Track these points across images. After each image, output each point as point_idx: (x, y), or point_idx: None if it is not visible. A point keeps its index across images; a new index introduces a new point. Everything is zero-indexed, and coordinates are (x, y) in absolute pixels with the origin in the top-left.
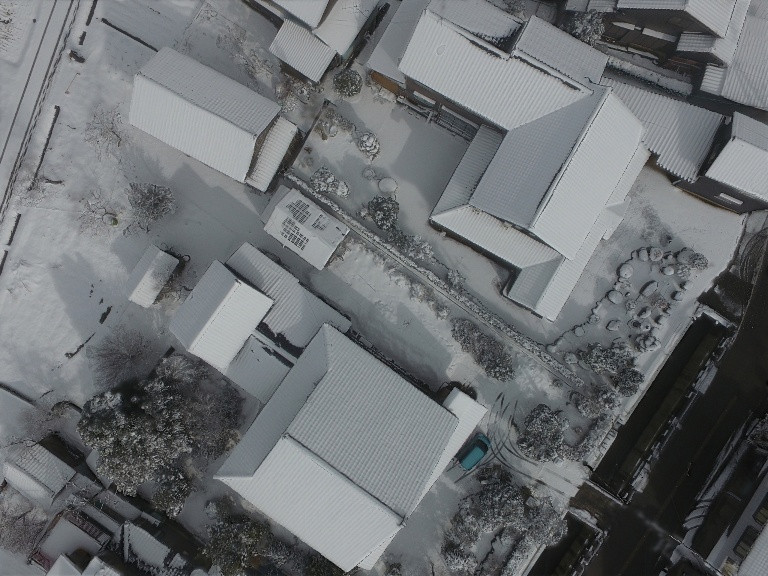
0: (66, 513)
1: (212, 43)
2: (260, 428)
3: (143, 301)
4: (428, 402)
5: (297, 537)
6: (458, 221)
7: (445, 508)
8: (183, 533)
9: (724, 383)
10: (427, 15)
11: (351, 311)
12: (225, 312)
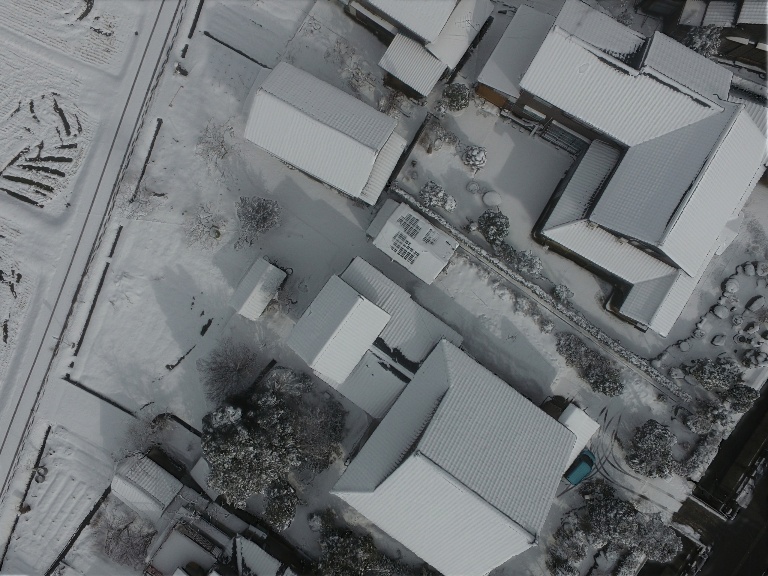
0: (179, 526)
1: (315, 56)
2: (378, 443)
3: (252, 314)
4: (546, 418)
5: (400, 550)
6: (571, 236)
7: (547, 522)
8: (285, 545)
9: None
10: (556, 31)
11: (455, 325)
12: (347, 328)
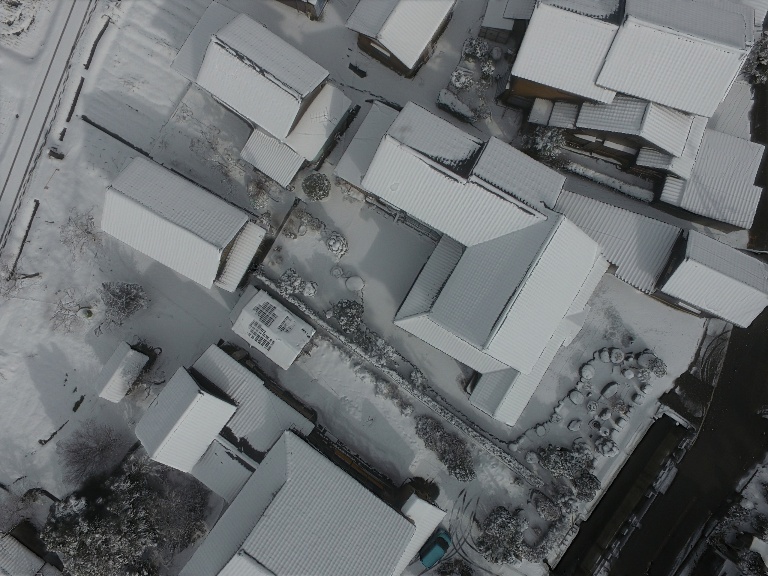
0: None
1: (187, 142)
2: (221, 532)
3: (113, 397)
4: (386, 510)
5: None
6: (420, 327)
7: None
8: None
9: (684, 484)
10: (387, 140)
11: (317, 406)
12: (188, 421)
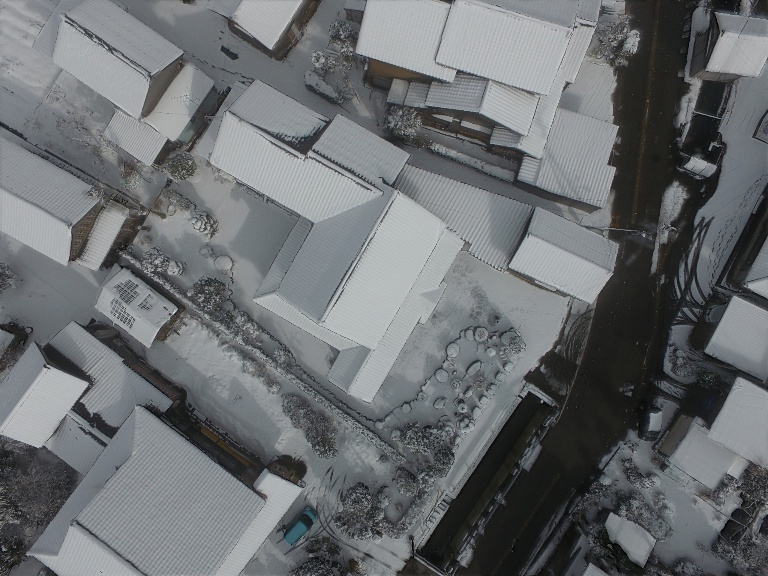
0: None
1: None
2: (71, 507)
3: None
4: (235, 484)
5: None
6: (278, 304)
7: None
8: None
9: (548, 461)
10: (227, 116)
11: (185, 385)
12: (35, 395)
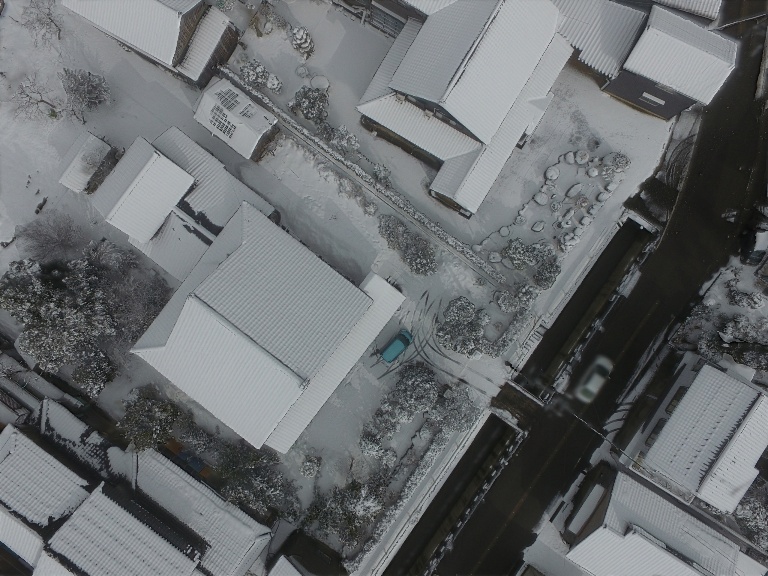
0: None
1: None
2: (176, 302)
3: (73, 185)
4: (343, 281)
5: (219, 426)
6: (382, 111)
7: (367, 404)
8: (108, 420)
9: (647, 287)
10: None
11: (280, 205)
12: (144, 183)
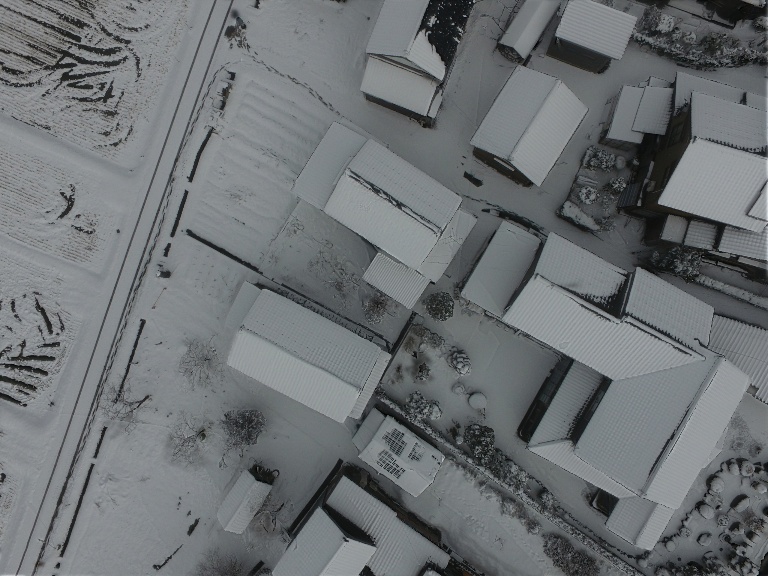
0: None
1: (299, 256)
2: None
3: (238, 529)
4: None
5: None
6: (556, 453)
7: None
8: None
9: None
10: (537, 280)
11: (442, 527)
12: (332, 568)
